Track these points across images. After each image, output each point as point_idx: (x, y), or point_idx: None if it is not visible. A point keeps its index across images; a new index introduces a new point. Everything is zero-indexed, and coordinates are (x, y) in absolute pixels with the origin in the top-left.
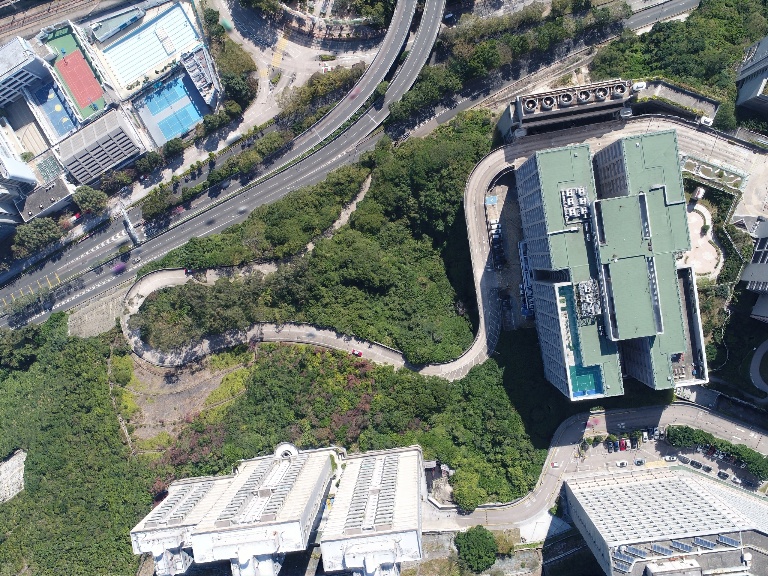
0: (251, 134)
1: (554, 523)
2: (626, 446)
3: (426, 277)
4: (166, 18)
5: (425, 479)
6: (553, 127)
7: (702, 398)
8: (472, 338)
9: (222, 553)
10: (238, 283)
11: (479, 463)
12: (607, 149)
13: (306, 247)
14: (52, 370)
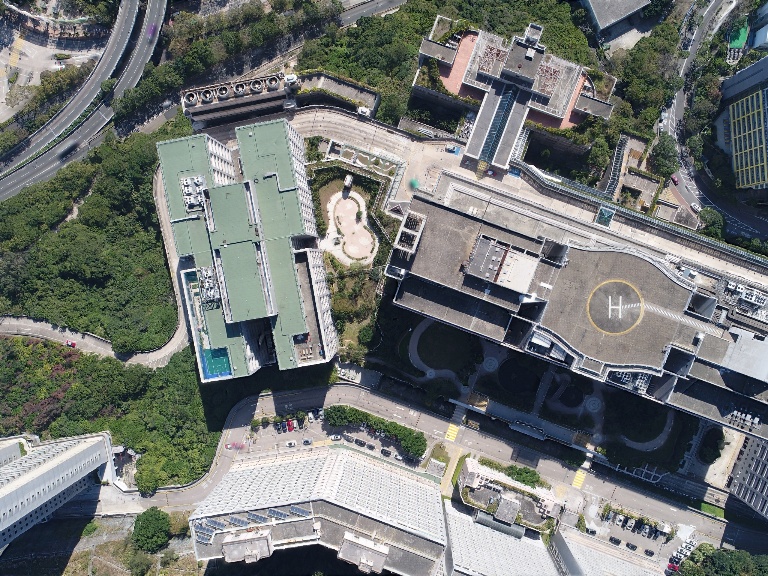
0: None
1: None
2: (293, 427)
3: (145, 268)
4: None
5: (111, 464)
6: None
7: (367, 379)
8: None
9: None
10: None
11: (166, 447)
12: None
13: None
14: None
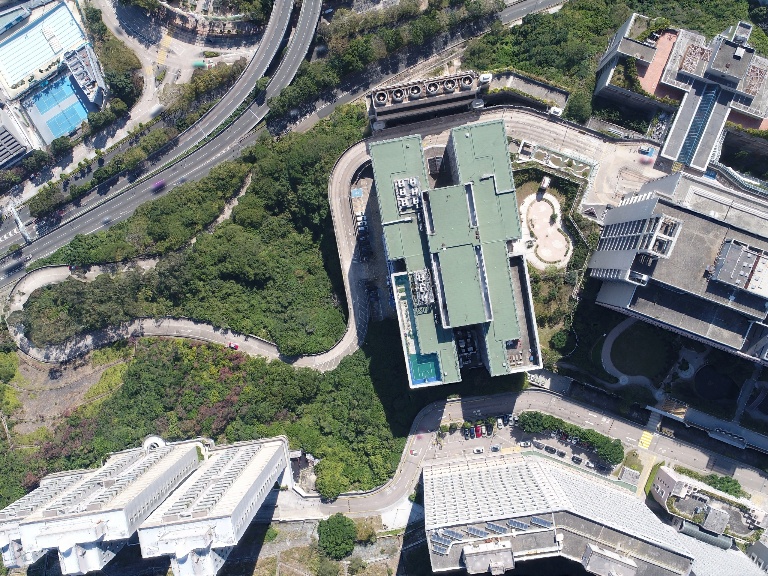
0: (138, 131)
1: (414, 510)
2: (482, 433)
3: (304, 270)
4: (52, 17)
5: (290, 469)
6: (417, 119)
7: (556, 384)
8: (345, 329)
9: (46, 542)
10: (118, 279)
11: (344, 452)
12: (449, 140)
13: (190, 242)
14: None
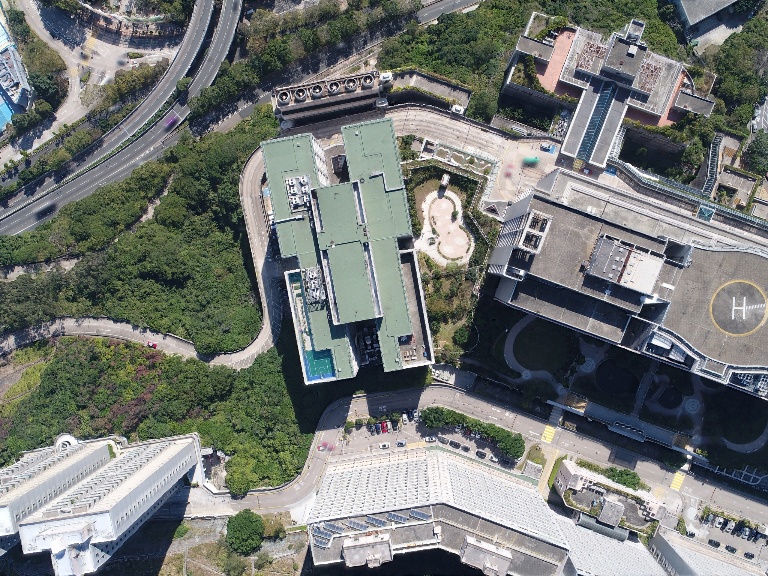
0: (64, 132)
1: None
2: (387, 428)
3: (224, 269)
4: None
5: (201, 466)
6: (328, 119)
7: (461, 380)
8: None
9: None
10: (39, 279)
11: (255, 449)
12: None
13: (114, 242)
14: None
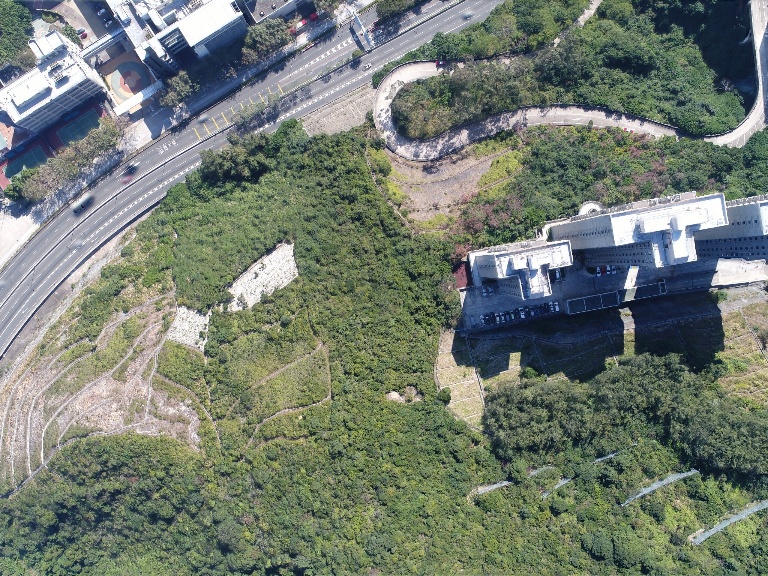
0: None
1: None
2: None
3: None
4: None
5: None
6: None
7: None
8: (744, 111)
9: (653, 226)
10: None
11: None
12: None
13: (553, 41)
14: (295, 172)
